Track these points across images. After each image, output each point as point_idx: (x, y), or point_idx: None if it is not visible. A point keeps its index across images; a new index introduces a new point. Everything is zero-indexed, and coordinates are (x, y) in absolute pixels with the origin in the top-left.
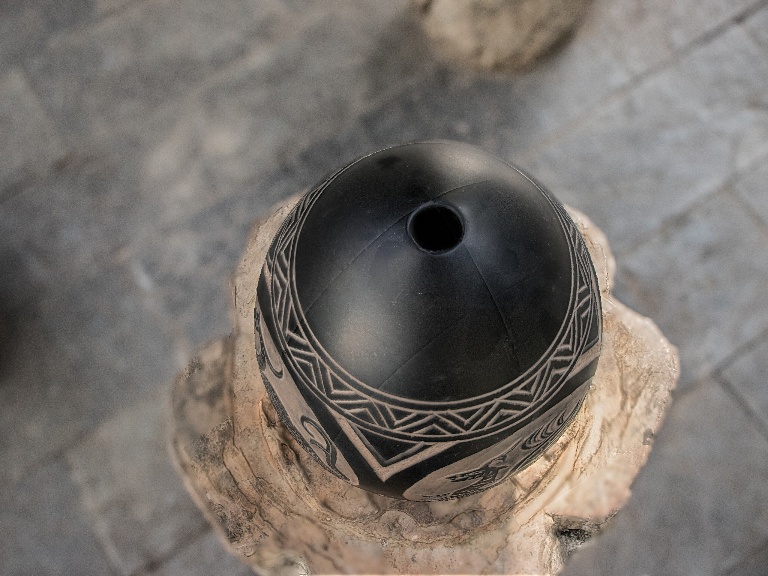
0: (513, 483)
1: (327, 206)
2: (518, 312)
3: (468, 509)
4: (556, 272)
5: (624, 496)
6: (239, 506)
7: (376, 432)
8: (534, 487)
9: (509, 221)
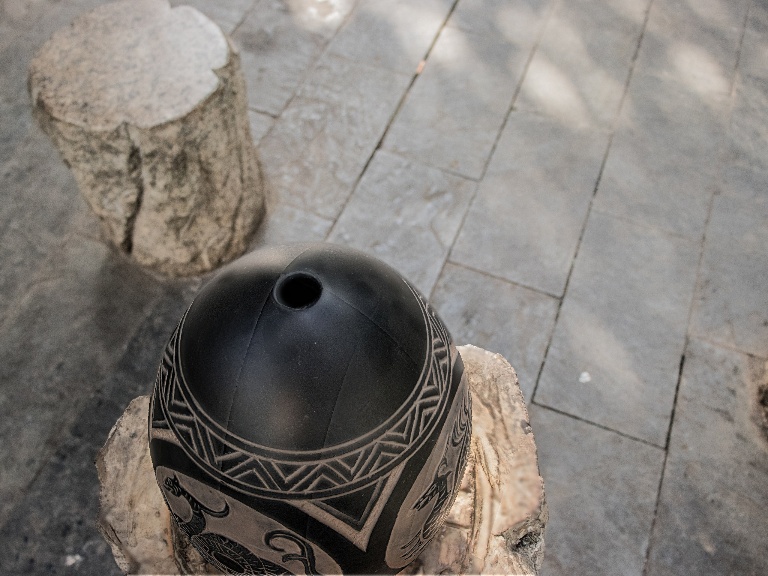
0: (456, 528)
1: (196, 334)
2: (392, 322)
3: (435, 575)
4: (398, 286)
5: (540, 482)
6: None
7: (339, 494)
8: (473, 521)
9: (345, 264)
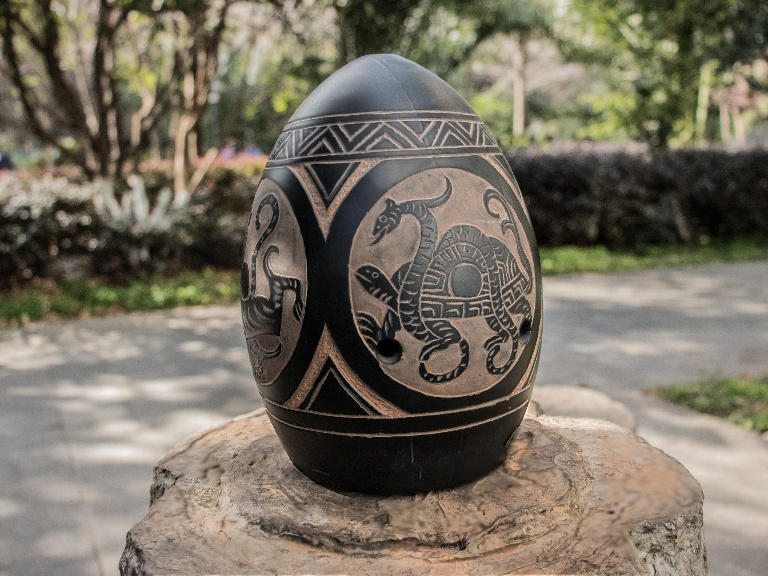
0: None
1: (335, 94)
2: None
3: None
4: None
5: None
6: (581, 575)
7: None
8: None
9: None
